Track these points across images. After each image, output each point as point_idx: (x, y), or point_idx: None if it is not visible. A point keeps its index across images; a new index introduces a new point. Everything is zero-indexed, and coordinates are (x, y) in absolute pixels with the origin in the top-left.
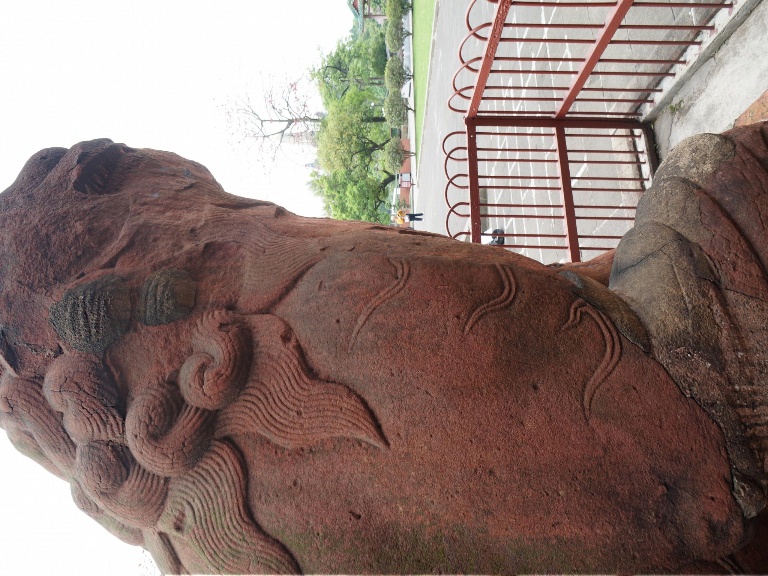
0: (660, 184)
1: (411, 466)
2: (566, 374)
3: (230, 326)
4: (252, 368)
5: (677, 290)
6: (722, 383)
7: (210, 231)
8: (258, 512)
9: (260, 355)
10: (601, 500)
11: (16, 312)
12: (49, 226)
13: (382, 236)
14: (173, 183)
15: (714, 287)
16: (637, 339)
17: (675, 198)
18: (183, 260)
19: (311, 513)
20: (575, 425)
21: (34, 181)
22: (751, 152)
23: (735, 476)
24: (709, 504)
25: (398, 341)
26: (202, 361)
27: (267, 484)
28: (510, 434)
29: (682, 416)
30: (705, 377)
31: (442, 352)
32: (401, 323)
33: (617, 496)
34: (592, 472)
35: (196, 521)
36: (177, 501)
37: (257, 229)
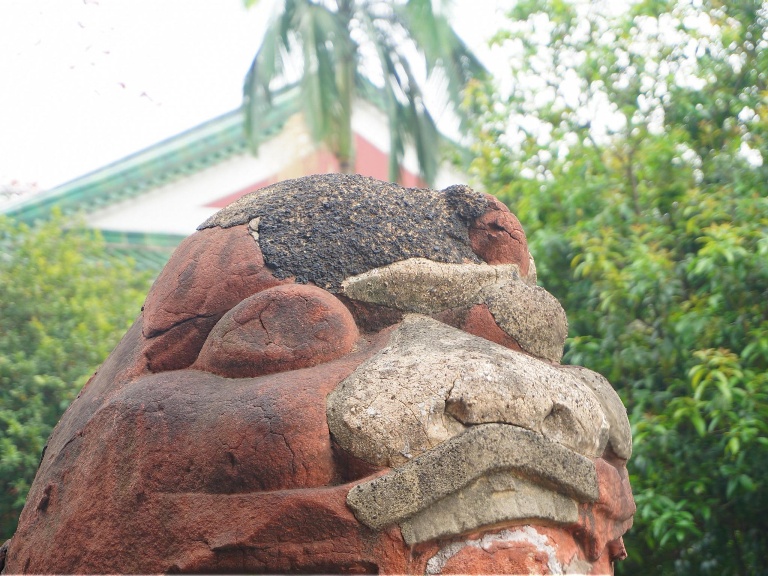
0: None
1: None
2: None
3: None
4: None
5: None
6: None
7: None
8: None
9: None
10: None
11: (10, 571)
12: (86, 575)
13: None
14: None
15: None
16: None
17: None
18: None
19: None
20: None
21: (181, 474)
22: None
23: None
24: None
25: None
26: None
27: None
28: None
29: None
30: None
31: None
32: None
33: None
34: None
35: None
36: None
37: None
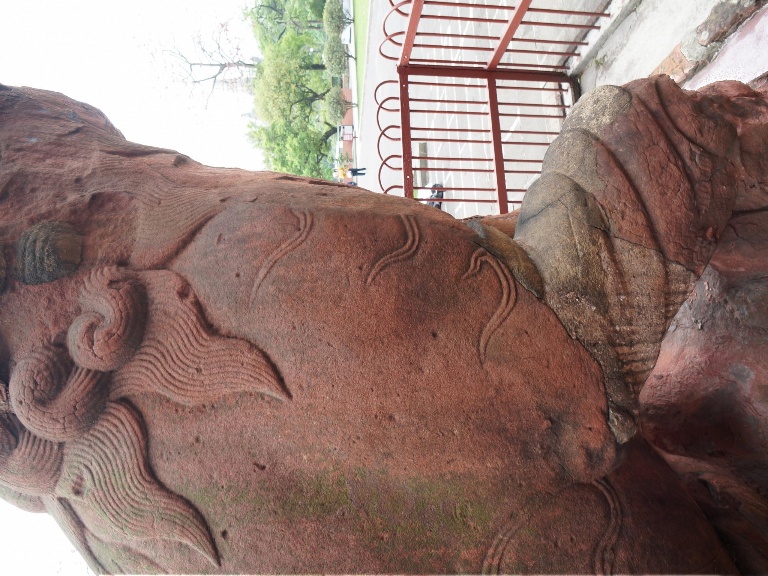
0: (564, 135)
1: (313, 416)
2: (464, 321)
3: (121, 283)
4: (147, 326)
5: (571, 238)
6: (604, 325)
7: (98, 181)
8: (160, 470)
9: (155, 312)
10: (492, 436)
11: None
12: None
13: (288, 186)
14: (55, 127)
15: (604, 235)
16: (531, 286)
17: (575, 149)
18: (66, 212)
19: (215, 468)
20: (471, 369)
21: None
22: (645, 104)
23: (611, 408)
24: (587, 434)
25: (300, 294)
26: (91, 321)
27: (168, 442)
28: (409, 380)
29: (567, 356)
30: (590, 320)
31: (344, 304)
32: (303, 276)
33: (506, 432)
34: (484, 412)
35: (95, 484)
36: (74, 465)
37: (153, 179)
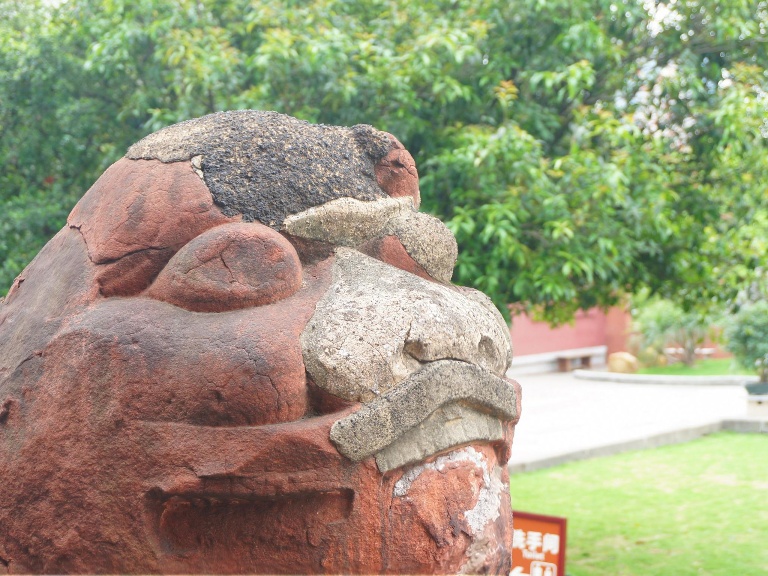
0: None
1: None
2: None
3: None
4: None
5: None
6: None
7: None
8: None
9: None
10: None
11: None
12: (61, 490)
13: None
14: None
15: None
16: None
17: None
18: None
19: None
20: None
21: (162, 405)
22: None
23: None
24: None
25: None
26: None
27: None
28: None
29: None
30: None
31: None
32: None
33: None
34: None
35: None
36: None
37: None
